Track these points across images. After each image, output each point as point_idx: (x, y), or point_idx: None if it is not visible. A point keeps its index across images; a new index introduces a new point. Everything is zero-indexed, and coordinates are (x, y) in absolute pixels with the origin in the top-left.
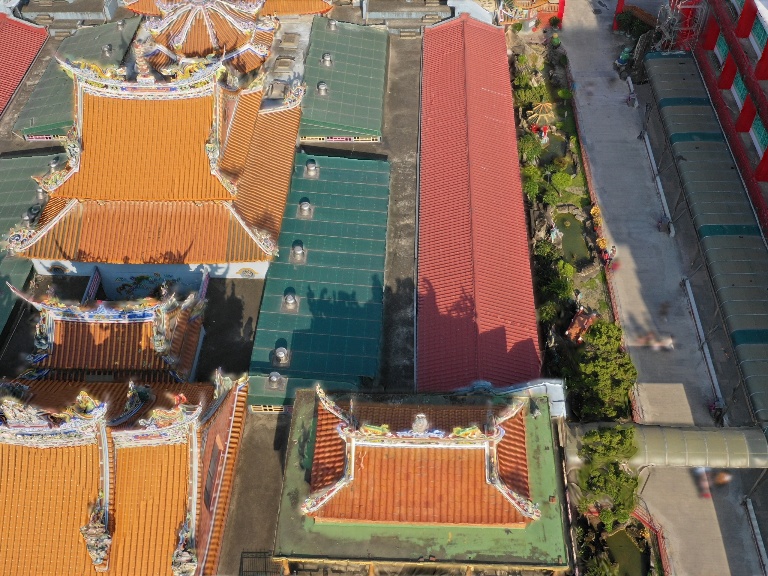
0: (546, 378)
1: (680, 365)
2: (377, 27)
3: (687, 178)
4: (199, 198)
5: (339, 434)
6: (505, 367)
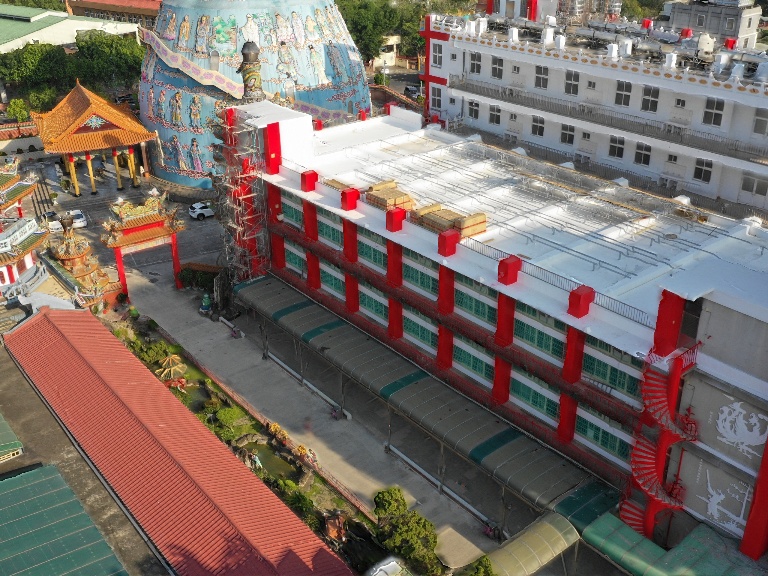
0: None
1: (437, 514)
2: None
3: (341, 361)
4: None
5: None
6: None
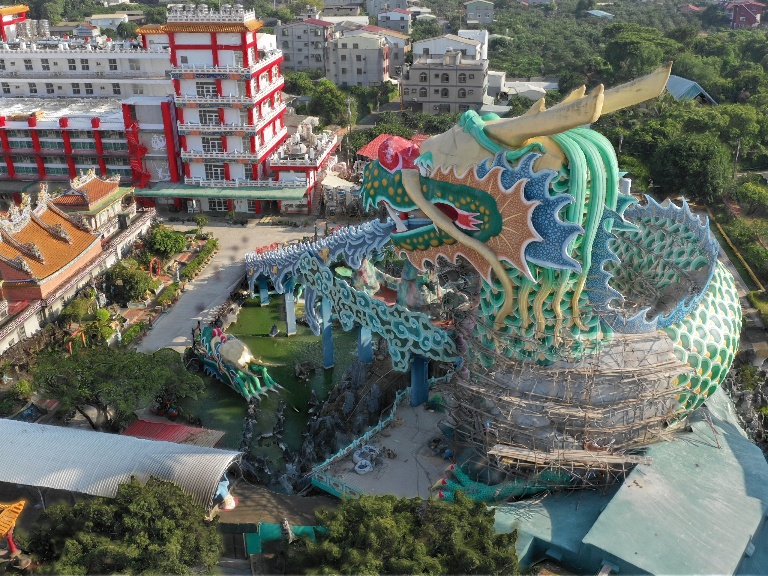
0: None
1: None
2: None
3: None
4: None
5: None
6: None
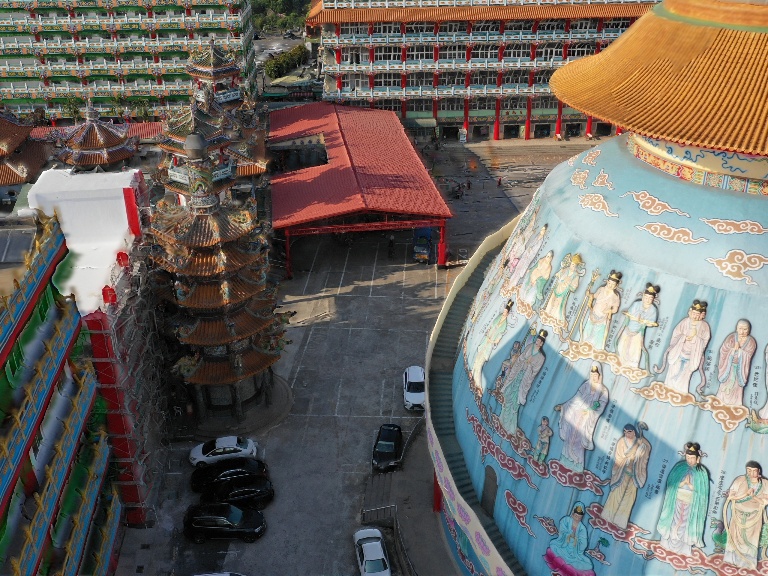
0: None
1: None
2: None
3: None
4: None
5: None
6: None
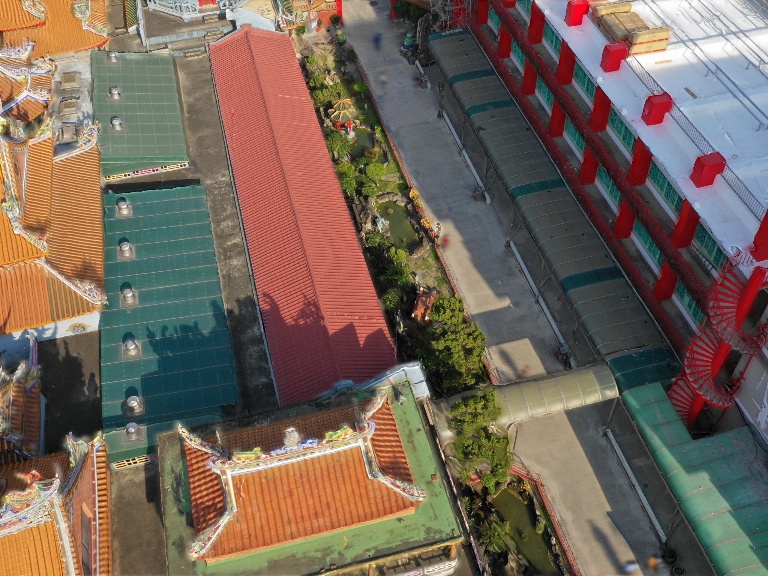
0: (403, 363)
1: (522, 321)
2: (160, 52)
3: (490, 146)
4: (7, 261)
5: (212, 469)
6: (362, 362)
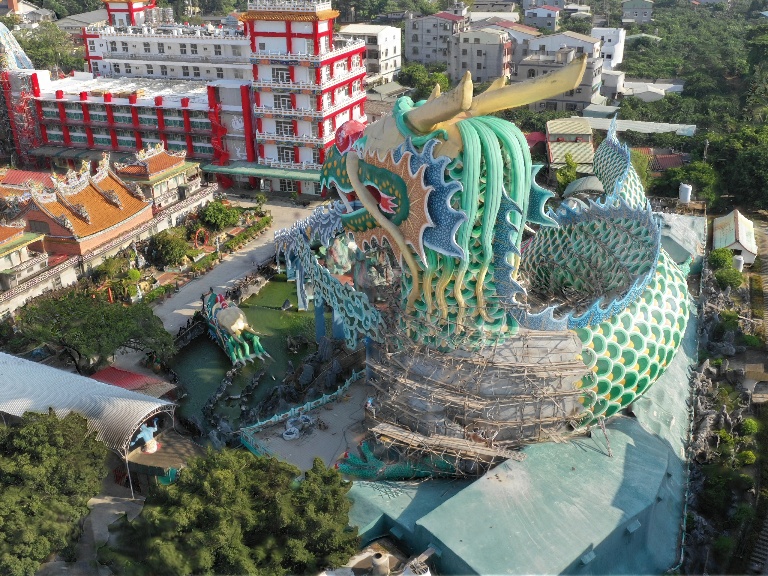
0: None
1: None
2: None
3: (97, 158)
4: None
5: None
6: None
